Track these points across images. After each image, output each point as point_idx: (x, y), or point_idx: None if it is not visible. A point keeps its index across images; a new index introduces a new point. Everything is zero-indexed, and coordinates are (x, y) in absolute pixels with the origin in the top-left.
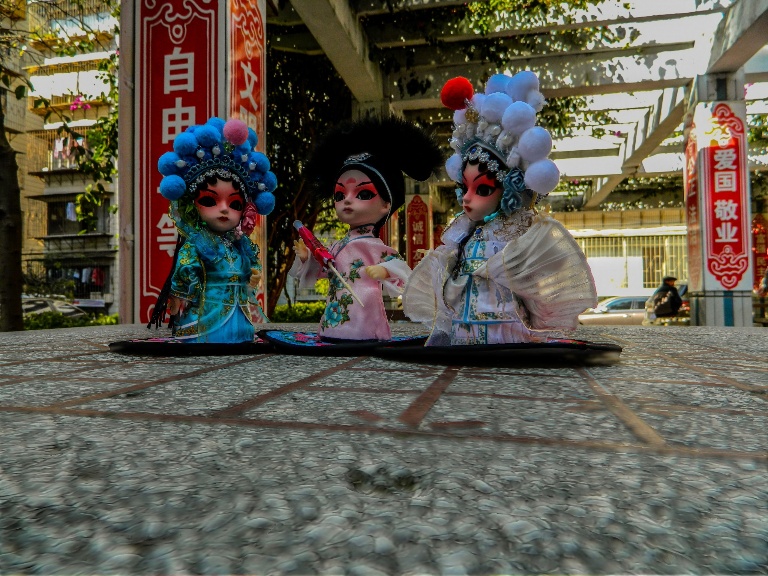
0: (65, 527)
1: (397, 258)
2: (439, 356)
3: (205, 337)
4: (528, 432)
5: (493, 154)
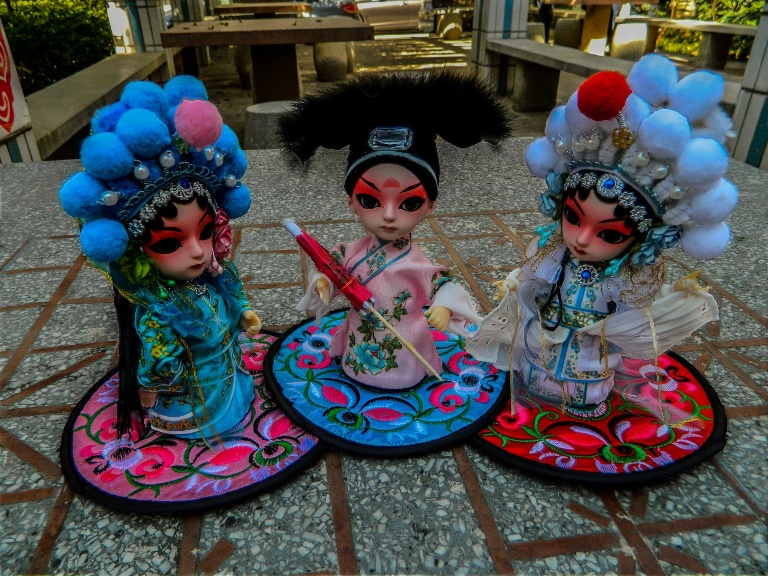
0: None
1: None
2: (587, 484)
3: (208, 430)
4: None
5: (642, 198)
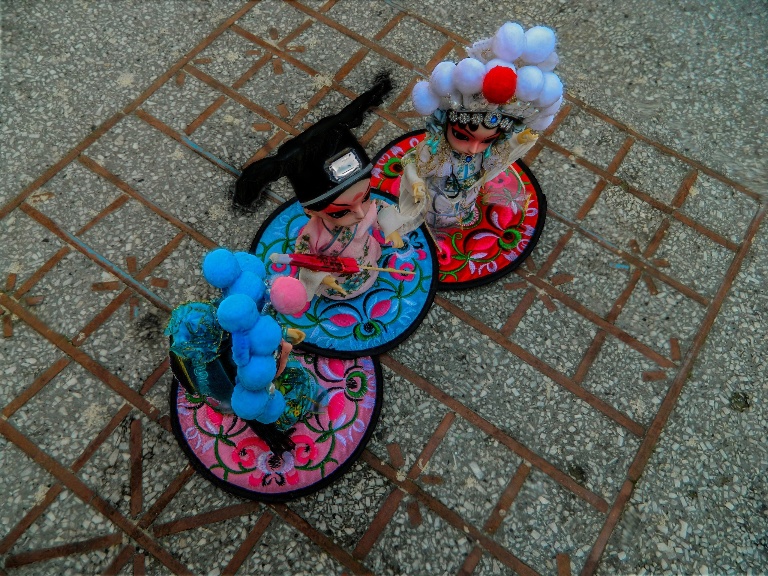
0: (760, 483)
1: (382, 206)
2: None
3: None
4: (686, 330)
5: None
